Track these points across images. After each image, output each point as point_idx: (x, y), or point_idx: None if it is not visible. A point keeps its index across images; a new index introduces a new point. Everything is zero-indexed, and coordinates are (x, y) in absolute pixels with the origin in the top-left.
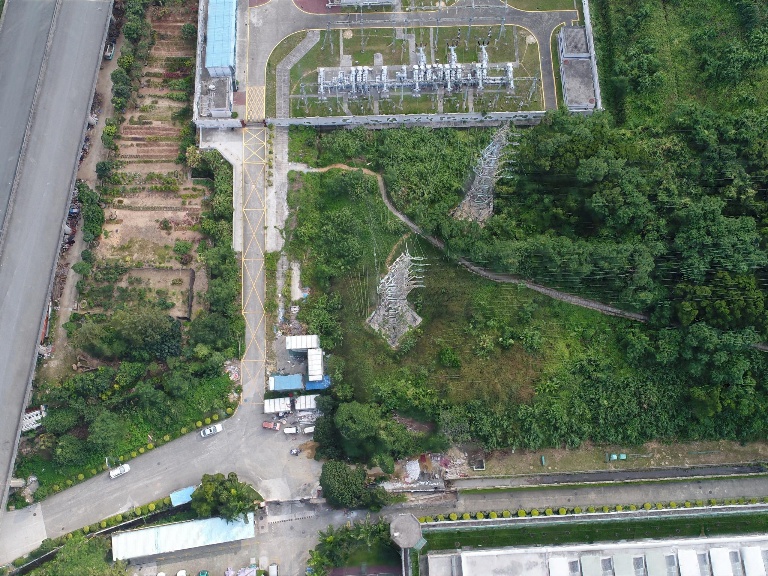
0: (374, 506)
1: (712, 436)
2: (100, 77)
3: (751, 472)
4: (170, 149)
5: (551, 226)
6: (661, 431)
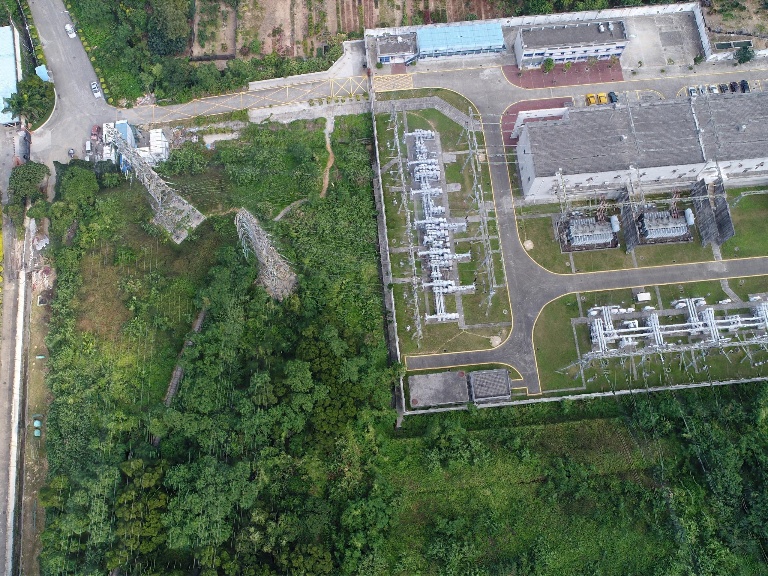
0: (7, 207)
1: None
2: None
3: (17, 570)
4: (352, 25)
5: None
6: None
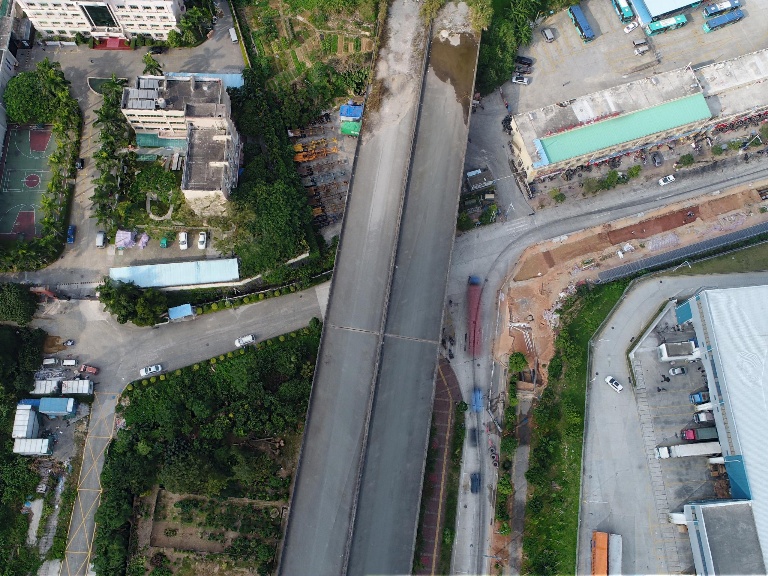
0: None
1: None
2: None
3: None
4: None
5: None
6: None
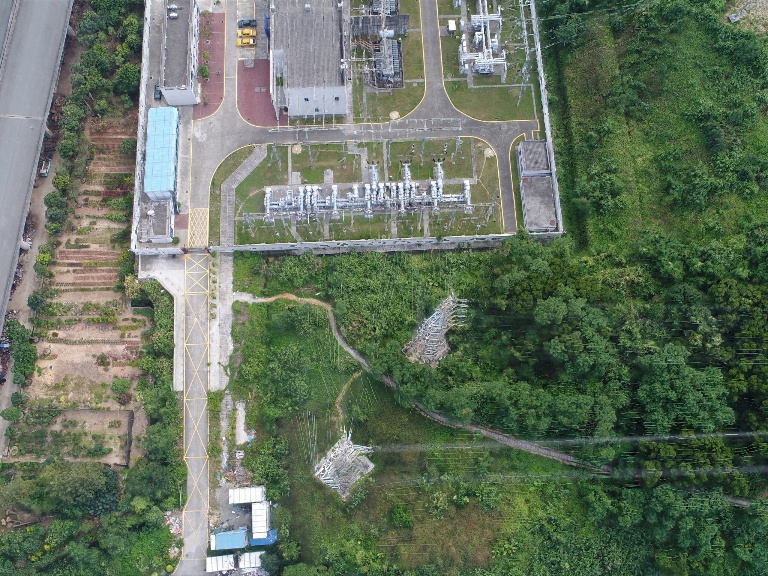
0: None
1: None
2: (35, 196)
3: None
4: (109, 275)
5: (509, 365)
6: None
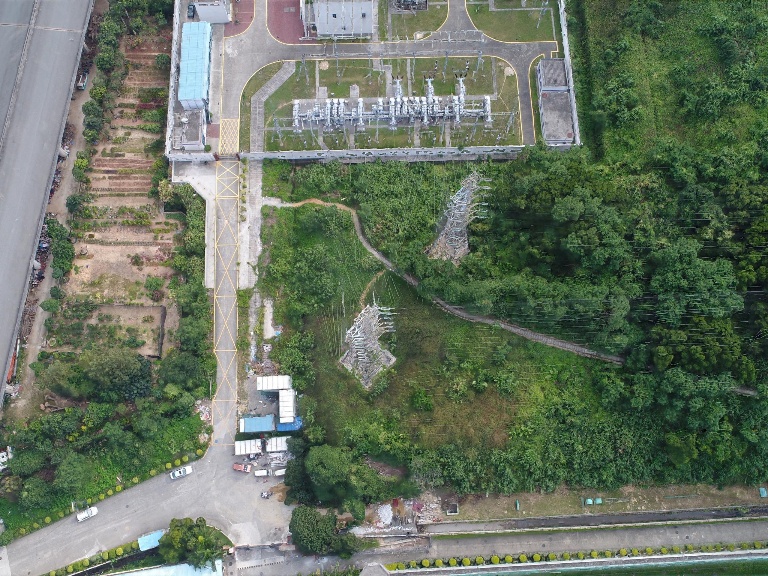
0: (344, 553)
1: (689, 480)
2: (72, 108)
3: (729, 516)
4: (143, 182)
5: (527, 264)
6: (637, 475)
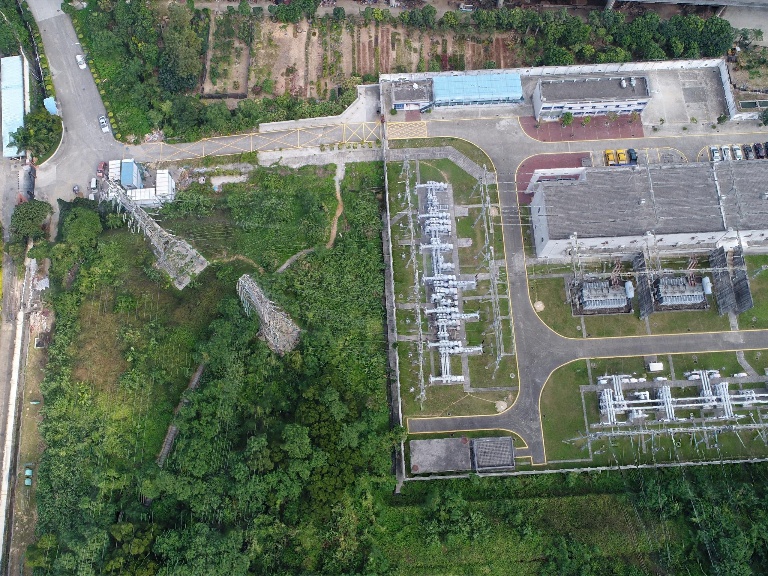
0: (8, 245)
1: None
2: (440, 4)
3: None
4: (367, 67)
5: None
6: None
